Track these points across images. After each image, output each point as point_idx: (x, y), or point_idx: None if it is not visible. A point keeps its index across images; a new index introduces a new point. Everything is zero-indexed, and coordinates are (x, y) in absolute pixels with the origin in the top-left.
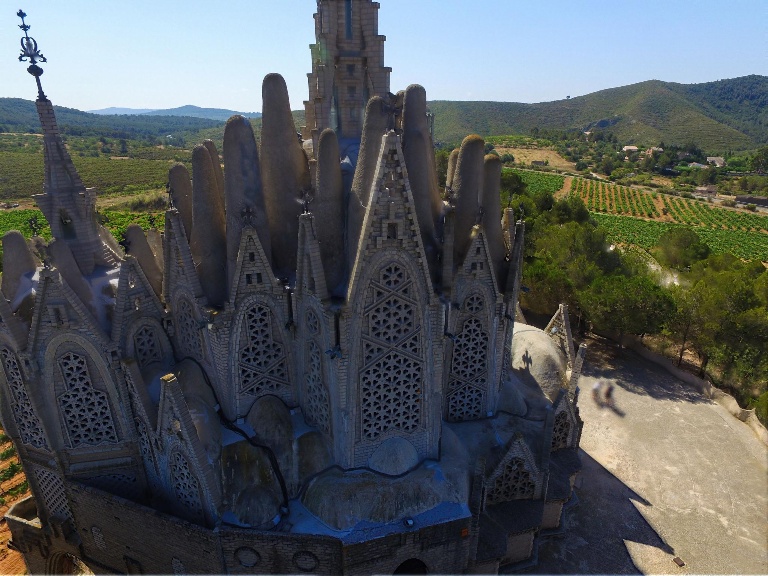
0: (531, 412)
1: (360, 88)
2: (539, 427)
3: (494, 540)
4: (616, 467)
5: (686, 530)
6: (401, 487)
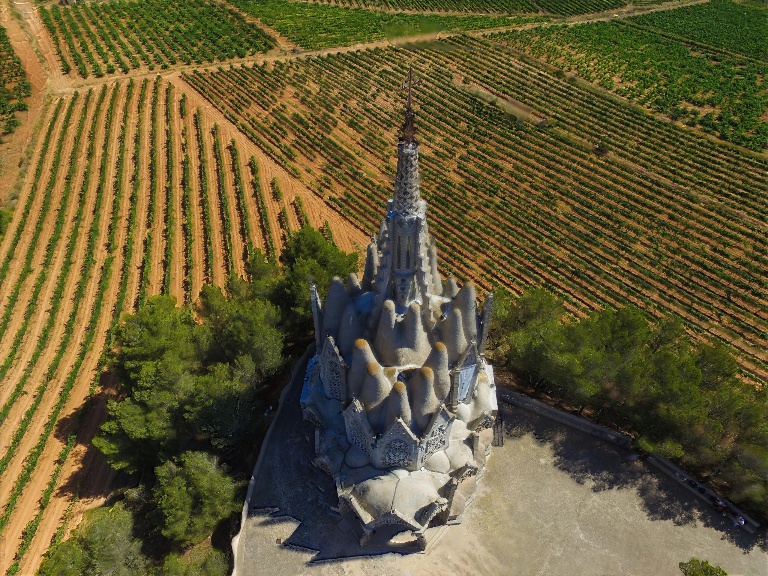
0: (347, 468)
1: (389, 279)
2: (332, 461)
3: (308, 429)
4: (342, 567)
5: (289, 567)
6: (315, 375)
